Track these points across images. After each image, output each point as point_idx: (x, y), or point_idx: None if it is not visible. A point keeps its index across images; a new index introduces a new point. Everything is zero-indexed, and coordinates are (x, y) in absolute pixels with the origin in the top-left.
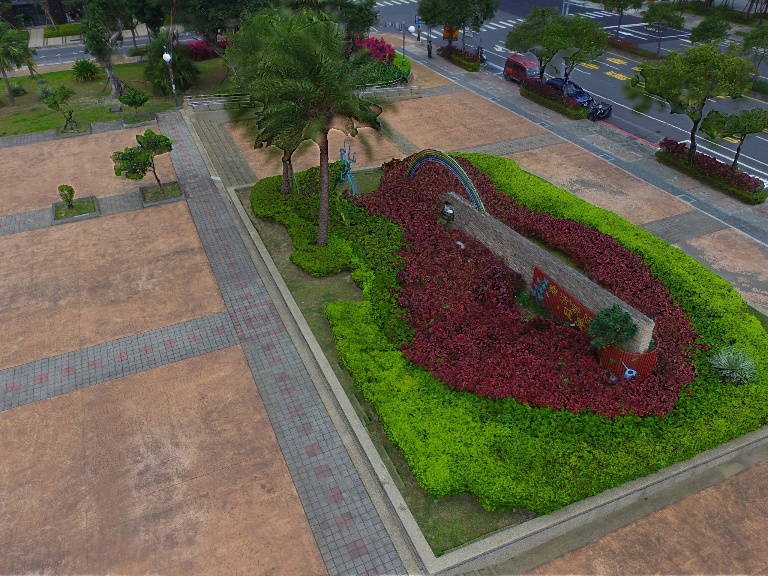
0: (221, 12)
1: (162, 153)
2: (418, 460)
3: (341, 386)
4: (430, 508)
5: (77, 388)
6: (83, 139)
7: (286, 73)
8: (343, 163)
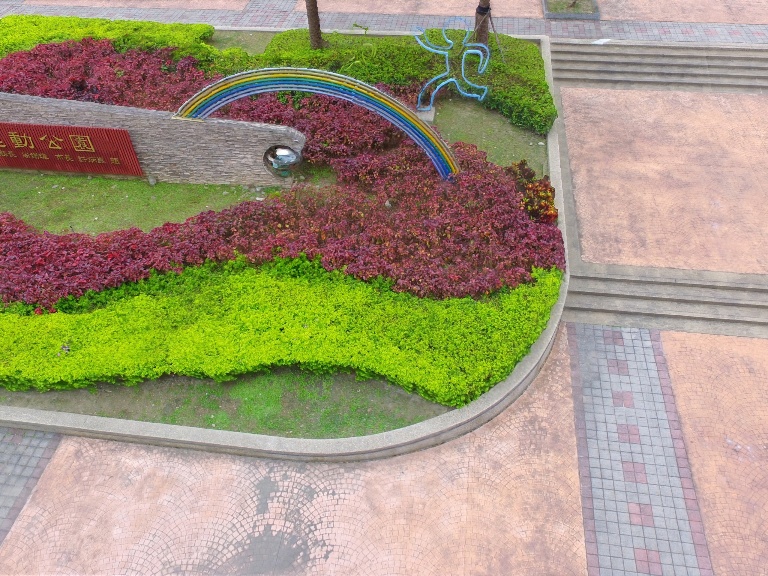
0: None
1: None
2: None
3: None
4: None
5: None
6: None
7: None
8: (537, 108)
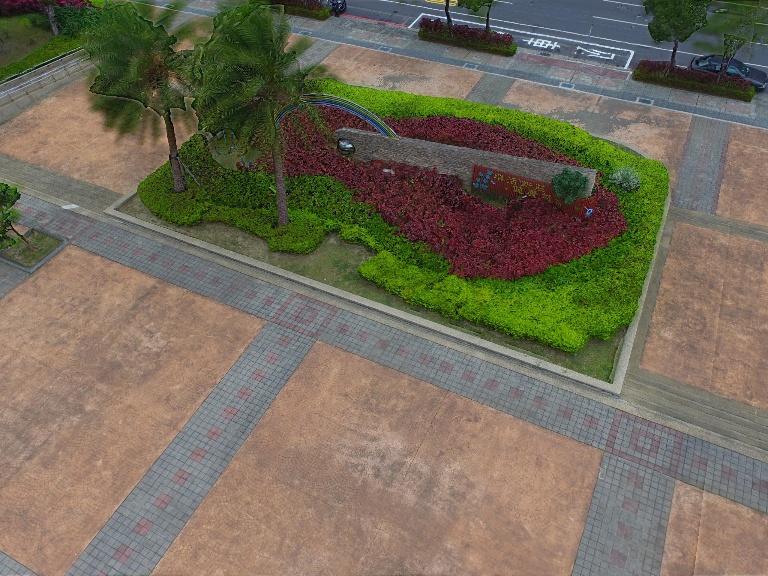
0: None
1: (13, 204)
2: (552, 336)
3: (436, 323)
4: (576, 361)
5: (228, 461)
6: None
7: (251, 70)
8: (200, 137)
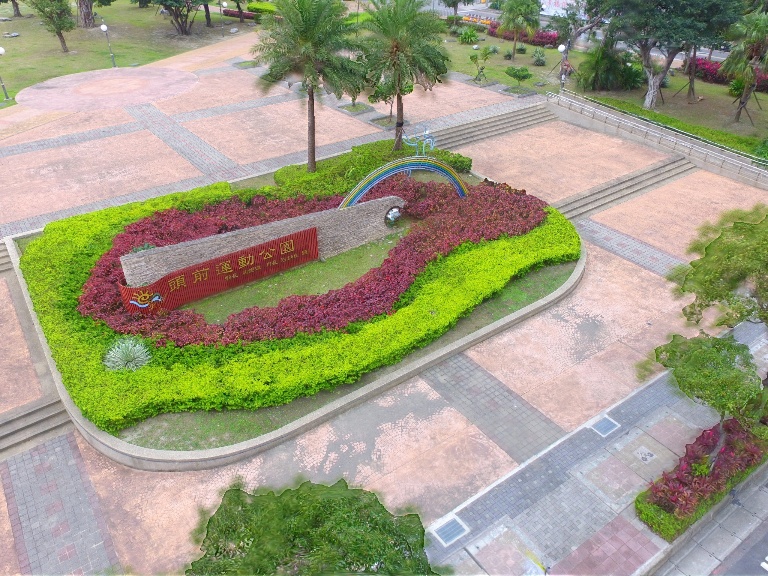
0: (626, 20)
1: None
2: None
3: None
4: None
5: None
6: (469, 88)
7: None
8: (462, 159)
